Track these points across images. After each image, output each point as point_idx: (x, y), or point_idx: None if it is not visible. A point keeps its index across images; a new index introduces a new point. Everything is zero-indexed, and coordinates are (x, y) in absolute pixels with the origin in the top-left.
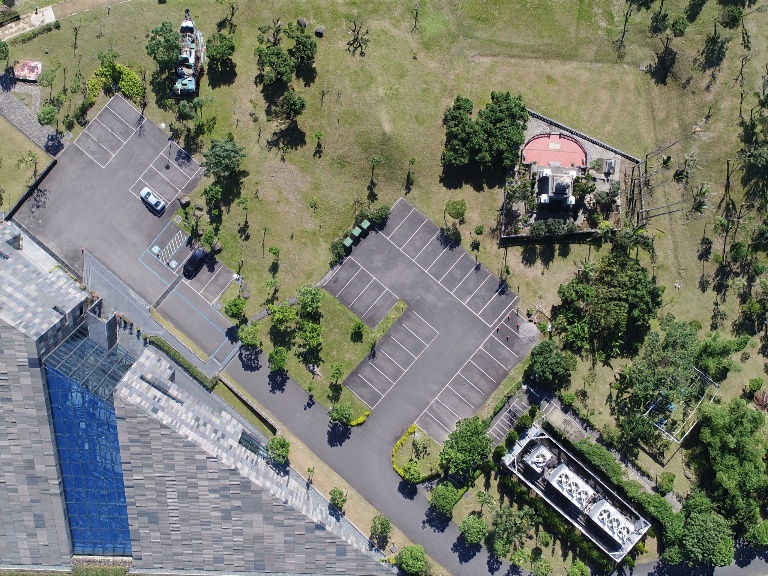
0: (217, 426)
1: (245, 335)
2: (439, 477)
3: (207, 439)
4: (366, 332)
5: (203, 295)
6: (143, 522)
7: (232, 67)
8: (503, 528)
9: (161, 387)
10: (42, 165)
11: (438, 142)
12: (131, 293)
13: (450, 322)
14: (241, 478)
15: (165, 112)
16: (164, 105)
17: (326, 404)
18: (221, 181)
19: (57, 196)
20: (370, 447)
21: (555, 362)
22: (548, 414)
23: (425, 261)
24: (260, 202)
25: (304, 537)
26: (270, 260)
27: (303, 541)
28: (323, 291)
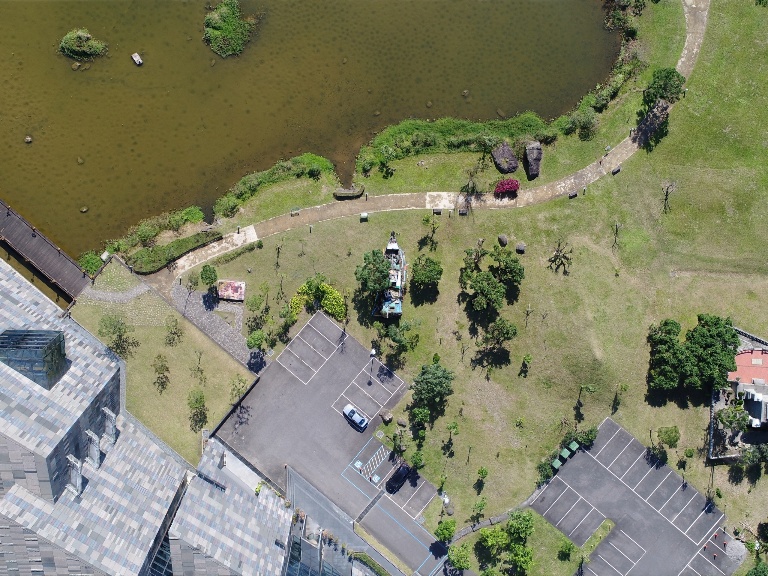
0: None
1: (457, 559)
2: None
3: None
4: None
5: (406, 510)
6: None
7: (434, 285)
8: None
9: None
10: None
11: (643, 361)
12: (334, 508)
13: (657, 540)
14: None
15: (367, 329)
16: (366, 322)
17: None
18: None
19: (260, 413)
20: None
21: None
22: None
23: (632, 480)
24: (465, 420)
25: None
26: (475, 477)
27: None
28: (530, 510)
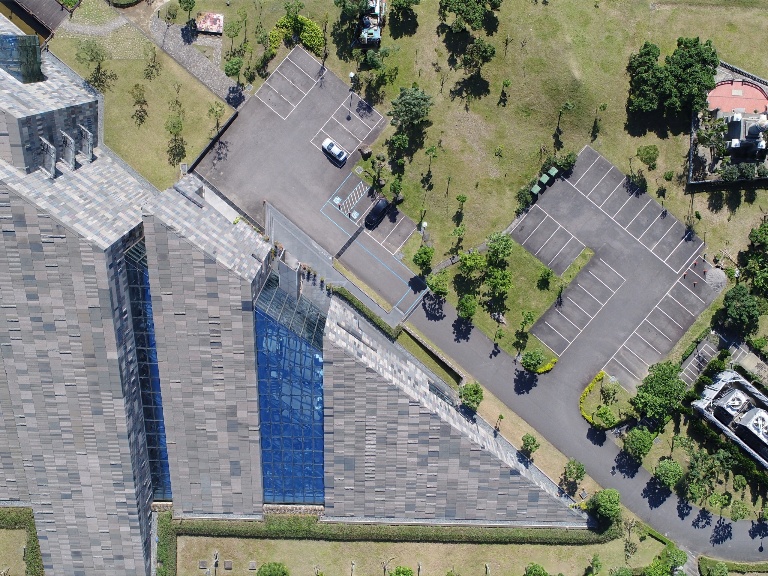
0: (408, 374)
1: (435, 283)
2: (628, 423)
3: (406, 384)
4: (553, 280)
5: (385, 245)
6: (339, 469)
7: (413, 17)
8: (699, 471)
9: (355, 334)
10: (224, 117)
11: (623, 89)
12: (313, 244)
13: (637, 269)
14: (442, 423)
15: (346, 63)
16: (345, 56)
17: (512, 352)
18: (403, 131)
19: (238, 148)
20: (557, 394)
21: (752, 305)
22: (736, 359)
23: (611, 208)
24: (444, 151)
25: (498, 483)
26: (454, 209)
27: (497, 487)
28: None
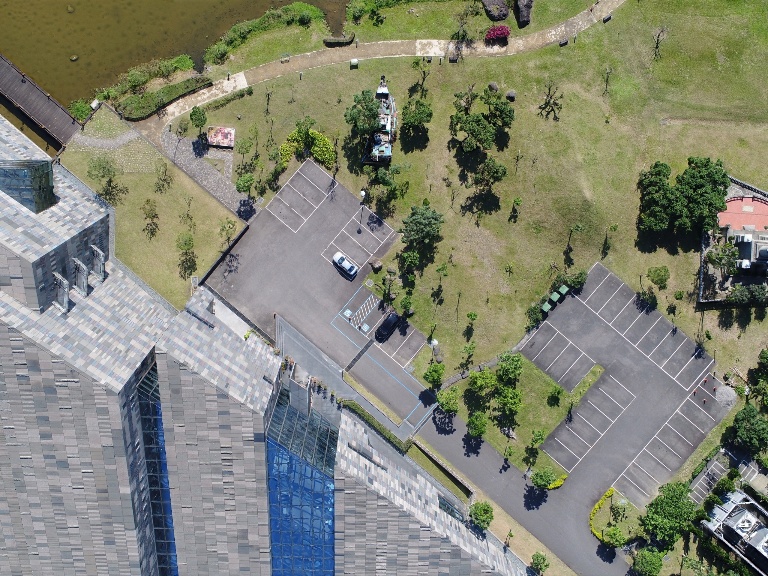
0: (419, 492)
1: (446, 401)
2: (638, 540)
3: (417, 507)
4: (563, 396)
5: (395, 358)
6: None
7: (424, 132)
8: None
9: (366, 454)
10: None
11: (633, 206)
12: (324, 357)
13: (647, 386)
14: (452, 546)
15: (357, 177)
16: (356, 170)
17: (522, 467)
18: None
19: (249, 261)
20: (567, 510)
21: (762, 428)
22: (746, 477)
23: (621, 325)
24: (454, 267)
25: None
26: (464, 324)
27: None
28: None
